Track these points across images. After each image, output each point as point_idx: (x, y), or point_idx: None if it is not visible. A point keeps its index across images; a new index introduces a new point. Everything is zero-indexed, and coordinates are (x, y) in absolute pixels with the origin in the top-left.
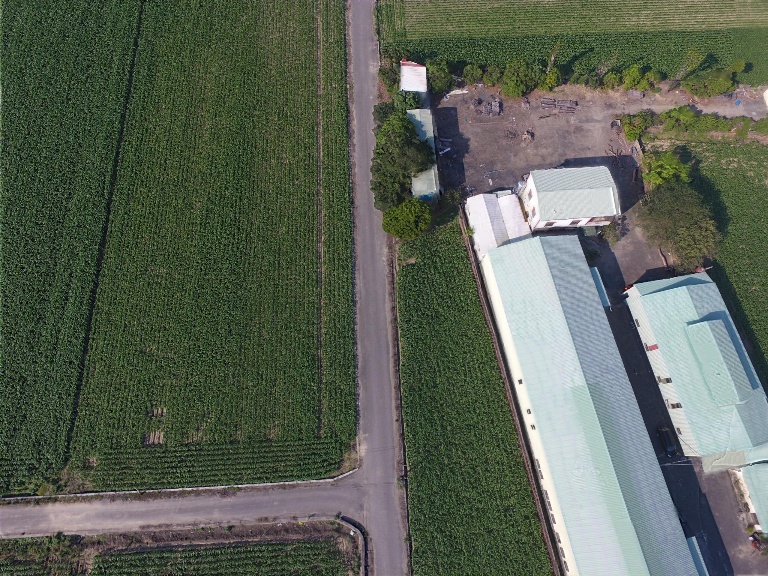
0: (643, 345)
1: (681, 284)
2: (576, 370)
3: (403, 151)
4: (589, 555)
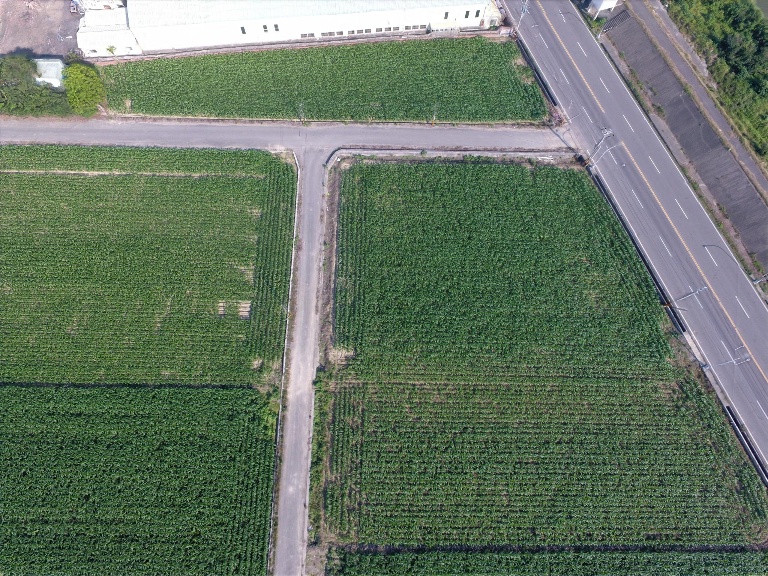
0: None
1: None
2: None
3: (7, 68)
4: (356, 3)
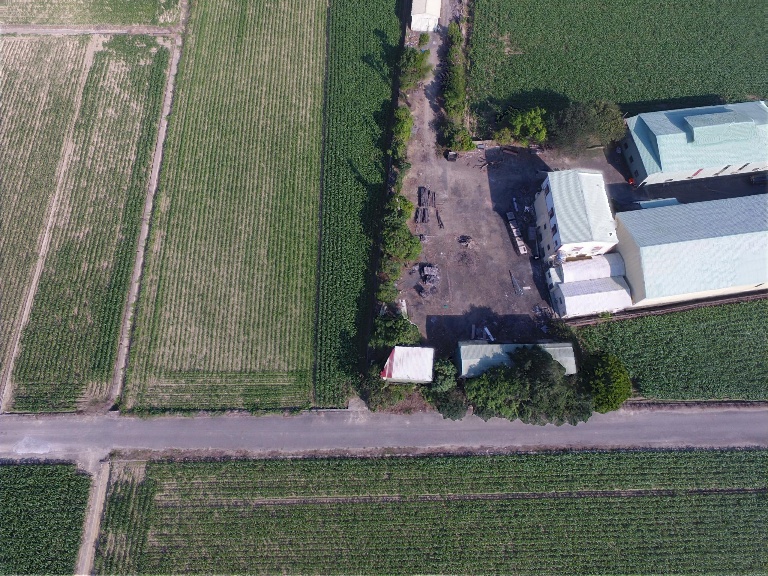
0: (685, 180)
1: (645, 139)
2: (766, 236)
3: None
4: None
